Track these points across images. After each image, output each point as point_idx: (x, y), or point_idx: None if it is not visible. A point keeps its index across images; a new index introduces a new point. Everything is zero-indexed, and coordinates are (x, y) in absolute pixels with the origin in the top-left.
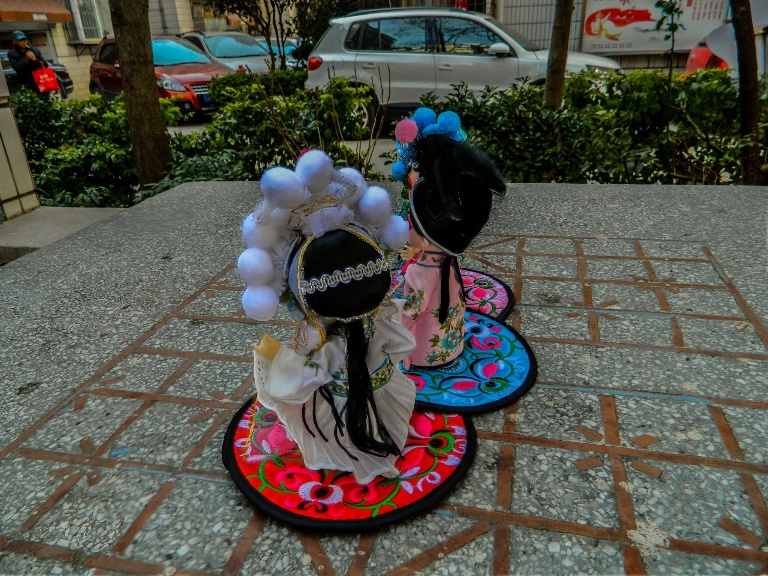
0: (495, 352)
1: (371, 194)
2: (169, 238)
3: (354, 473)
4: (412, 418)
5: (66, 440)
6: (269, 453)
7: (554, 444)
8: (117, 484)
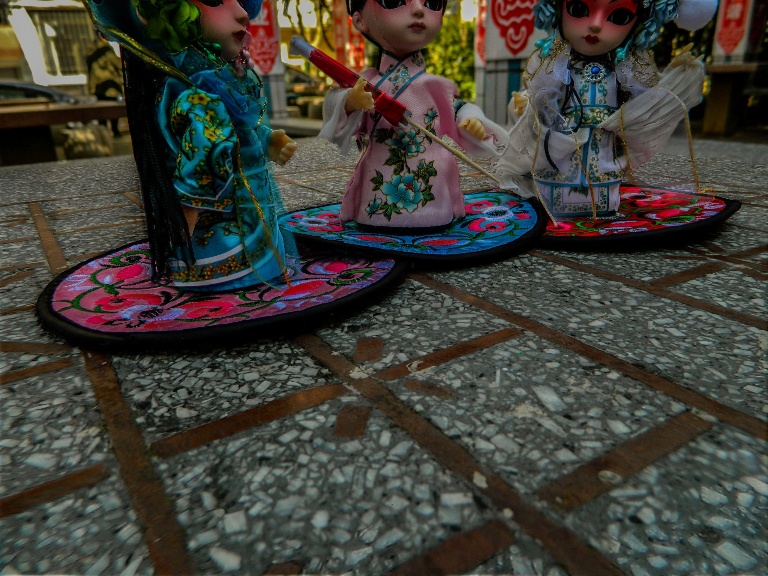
0: None
1: None
2: None
3: None
4: None
5: None
6: (683, 207)
7: None
8: None
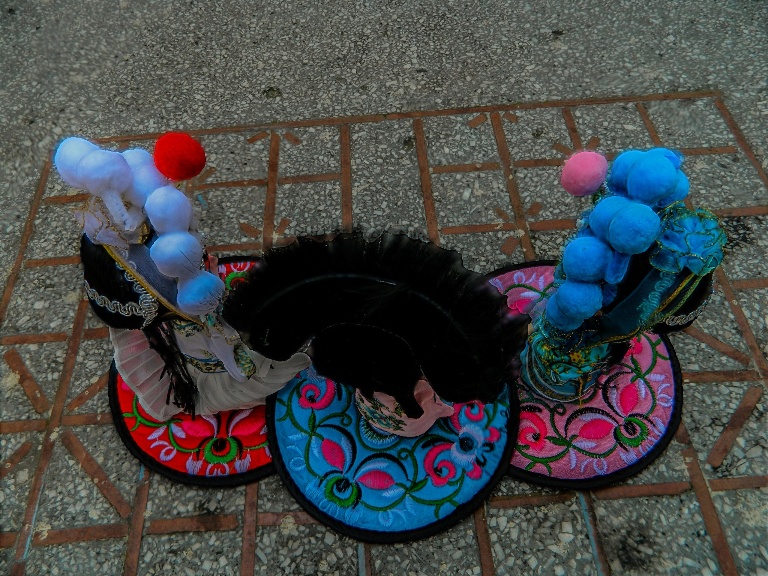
0: (420, 480)
1: (155, 244)
2: (617, 4)
3: (128, 384)
4: (260, 411)
5: (211, 158)
6: None
7: (245, 575)
8: None
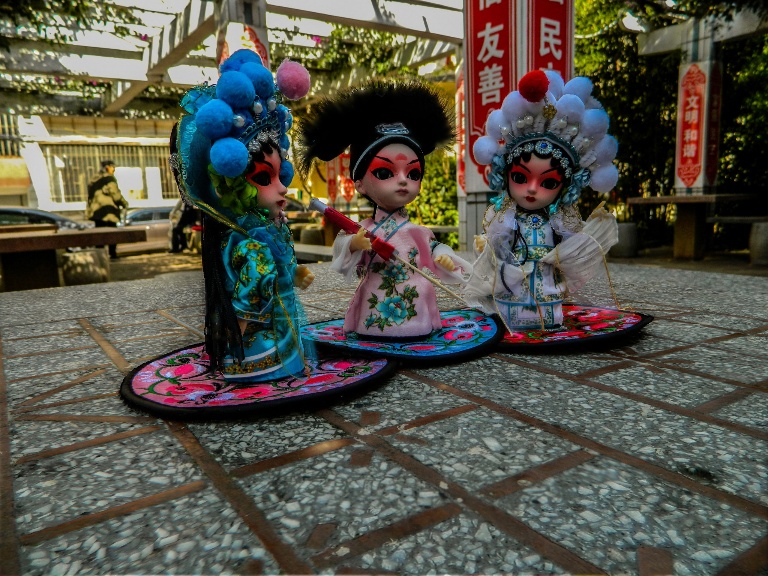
0: None
1: None
2: None
3: None
4: None
5: None
6: None
7: None
8: (765, 351)
